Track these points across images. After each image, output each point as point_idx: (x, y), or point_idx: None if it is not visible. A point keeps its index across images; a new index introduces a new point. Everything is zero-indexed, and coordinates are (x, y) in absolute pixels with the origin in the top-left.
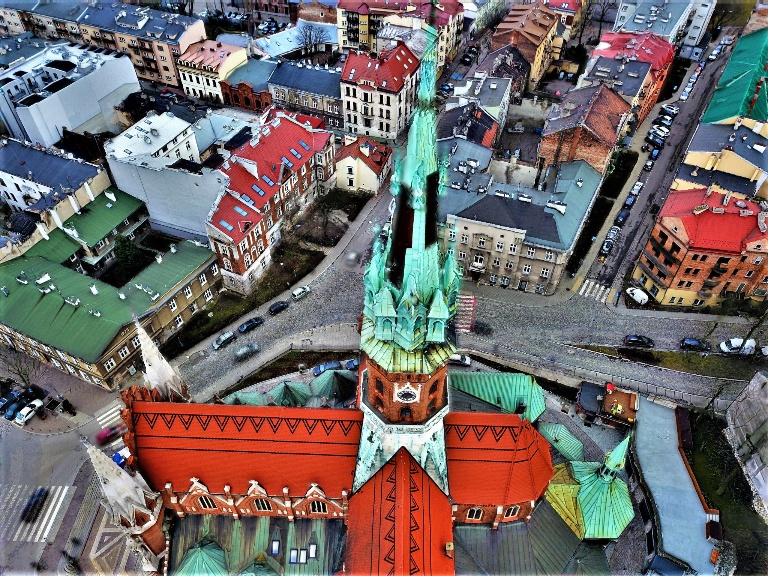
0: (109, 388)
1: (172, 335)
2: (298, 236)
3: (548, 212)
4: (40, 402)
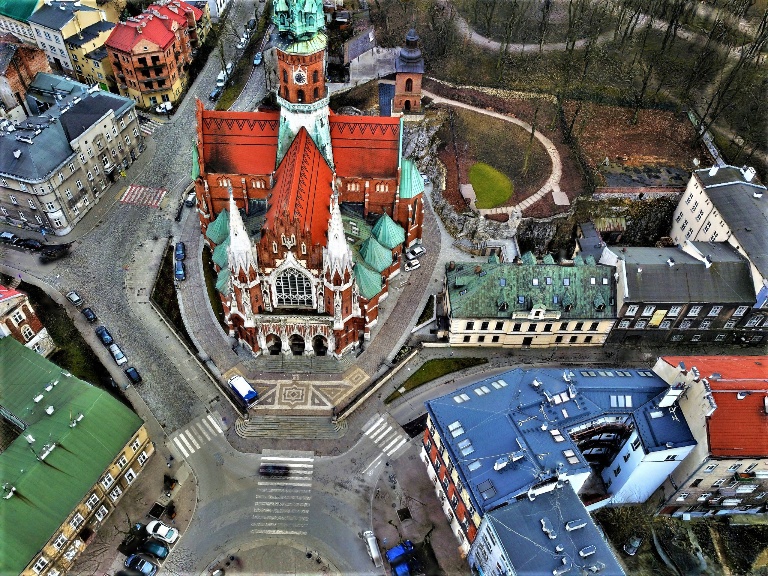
0: (153, 448)
1: None
2: None
3: (96, 96)
4: (152, 522)
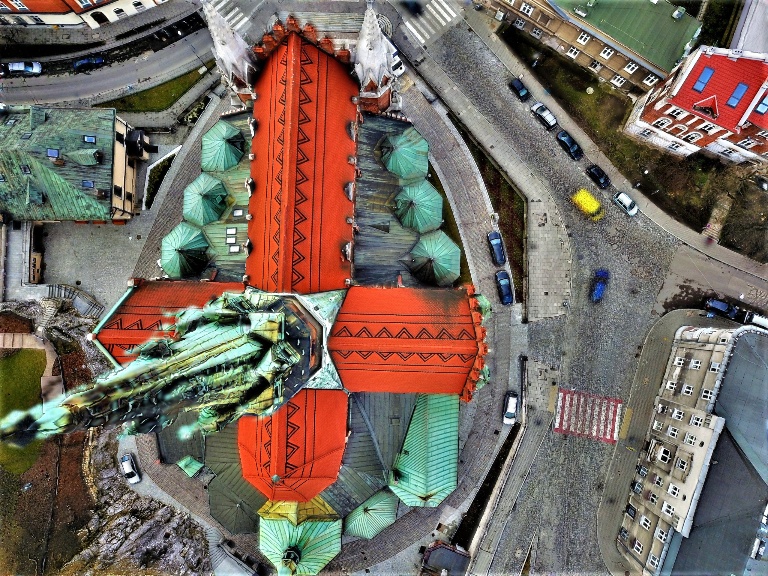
0: None
1: (555, 49)
2: (743, 189)
3: None
4: None
